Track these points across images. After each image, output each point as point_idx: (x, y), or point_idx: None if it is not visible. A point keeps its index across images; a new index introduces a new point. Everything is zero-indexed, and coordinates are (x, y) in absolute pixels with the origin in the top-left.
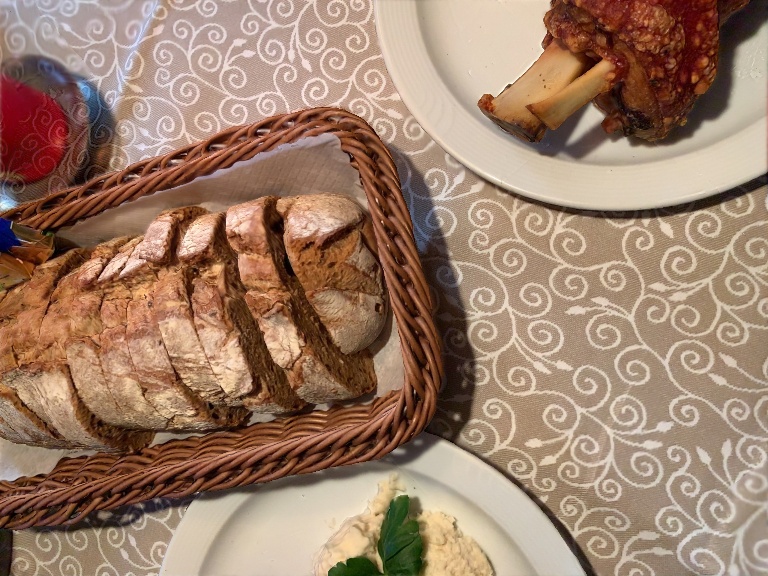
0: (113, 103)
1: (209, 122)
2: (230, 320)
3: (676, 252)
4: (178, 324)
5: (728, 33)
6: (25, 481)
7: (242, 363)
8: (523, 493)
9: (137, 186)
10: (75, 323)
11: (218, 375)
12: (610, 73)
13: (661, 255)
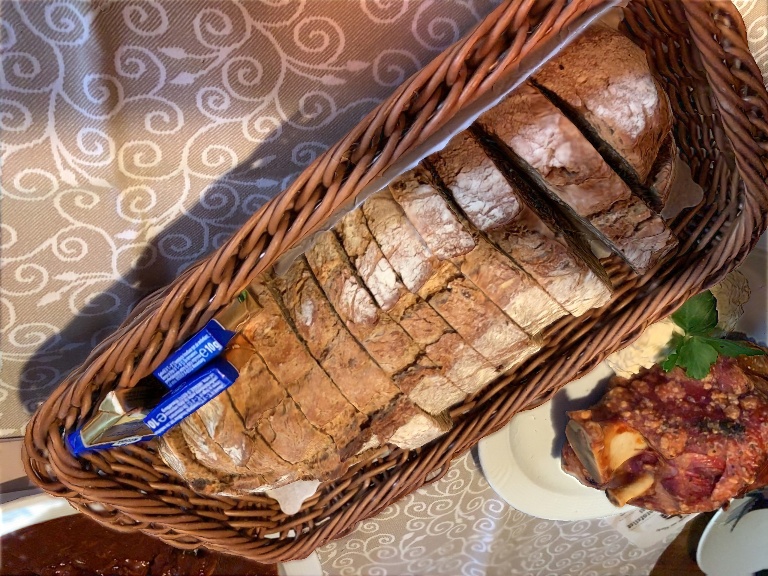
0: (83, 29)
1: None
2: (579, 259)
3: None
4: (526, 297)
5: None
6: (327, 485)
7: (601, 287)
8: None
9: (373, 176)
10: (390, 365)
11: (573, 310)
12: None
13: None
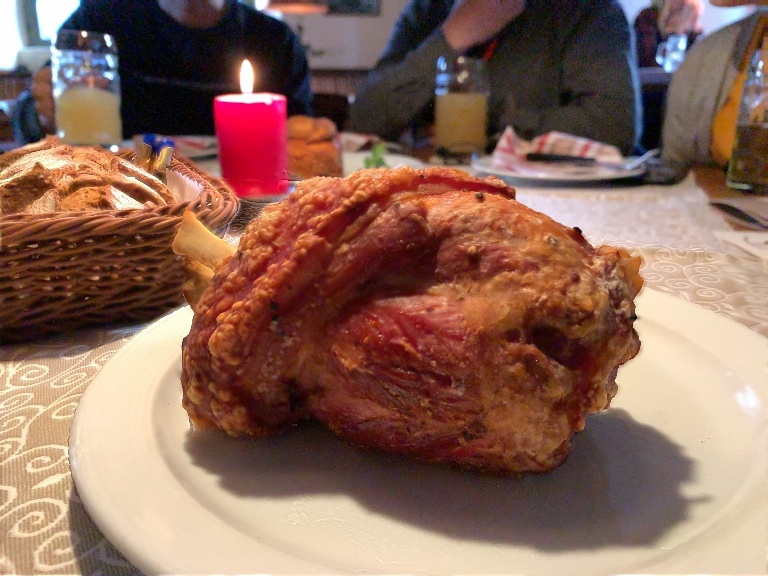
0: None
1: None
2: None
3: (5, 496)
4: None
5: (367, 479)
6: None
7: (8, 180)
8: None
9: None
10: None
11: None
12: (230, 255)
13: (9, 483)
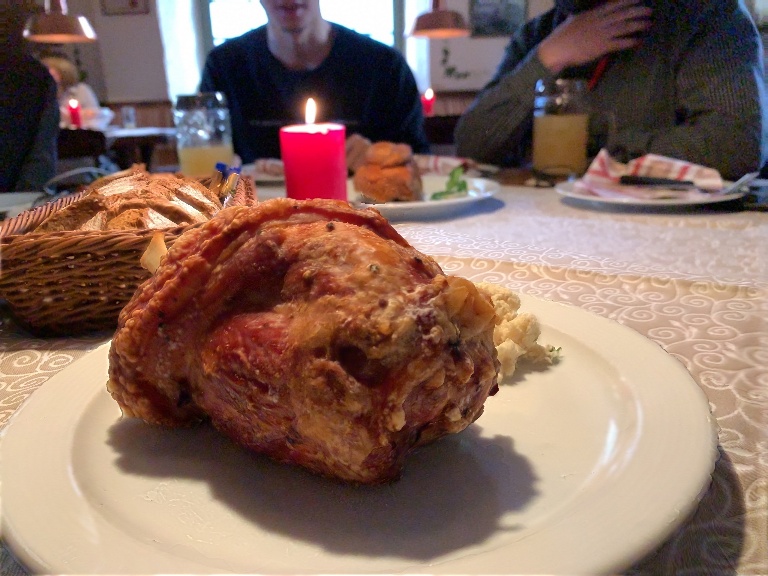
0: None
1: None
2: None
3: None
4: None
5: (229, 472)
6: None
7: None
8: None
9: None
10: None
11: None
12: None
13: None
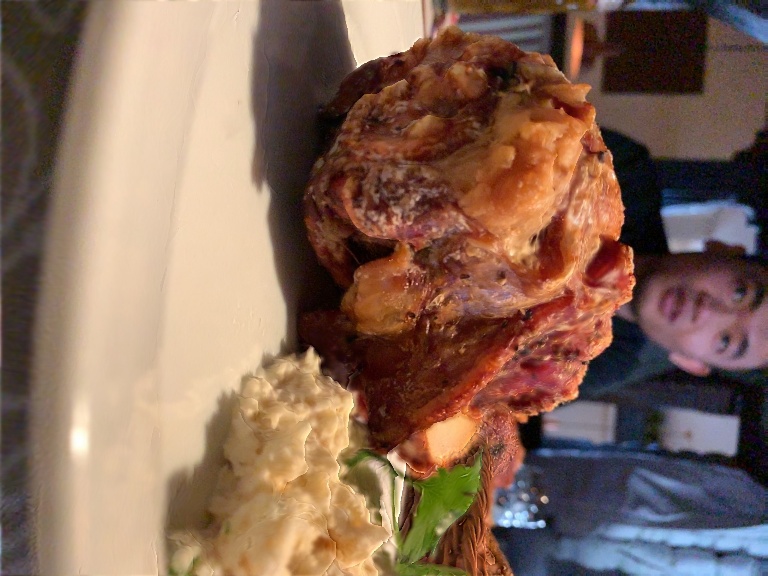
0: None
1: None
2: None
3: None
4: None
5: None
6: None
7: None
8: None
9: None
10: None
11: None
12: None
13: None
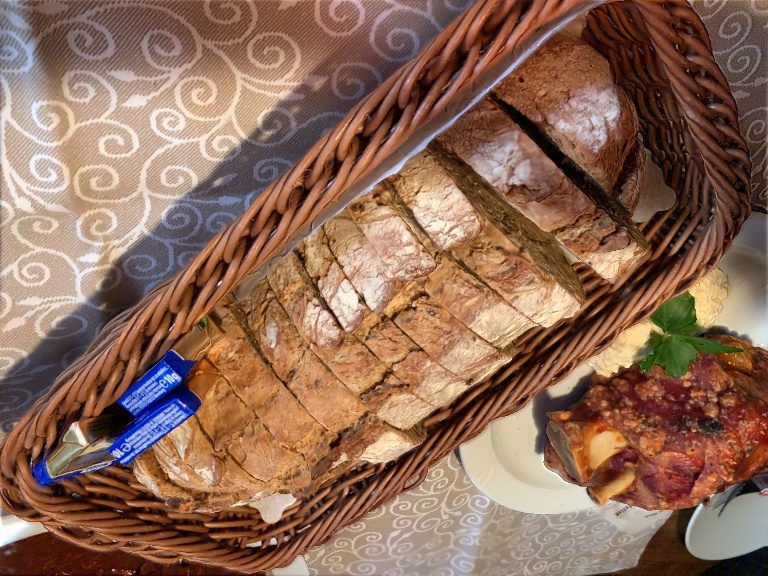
0: (26, 56)
1: (230, 4)
2: (545, 273)
3: None
4: (492, 314)
5: None
6: None
7: (569, 299)
8: (760, 214)
9: (327, 202)
10: (356, 385)
11: (542, 322)
12: None
13: None
